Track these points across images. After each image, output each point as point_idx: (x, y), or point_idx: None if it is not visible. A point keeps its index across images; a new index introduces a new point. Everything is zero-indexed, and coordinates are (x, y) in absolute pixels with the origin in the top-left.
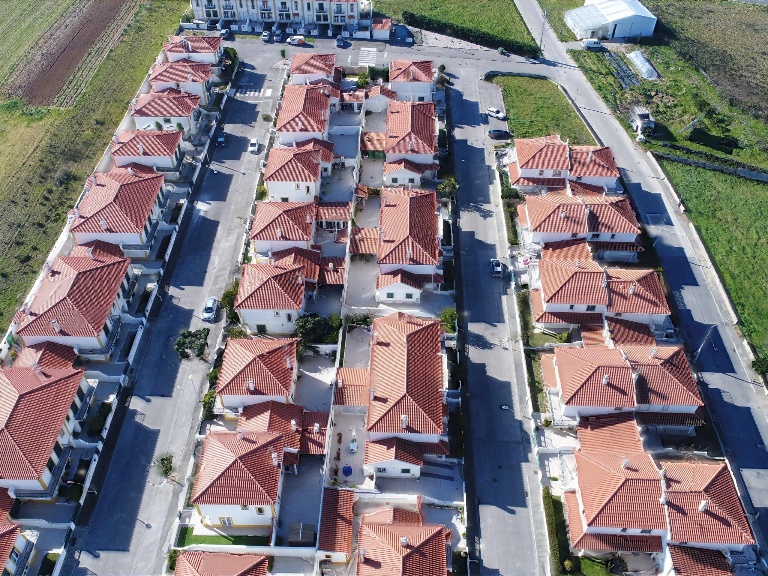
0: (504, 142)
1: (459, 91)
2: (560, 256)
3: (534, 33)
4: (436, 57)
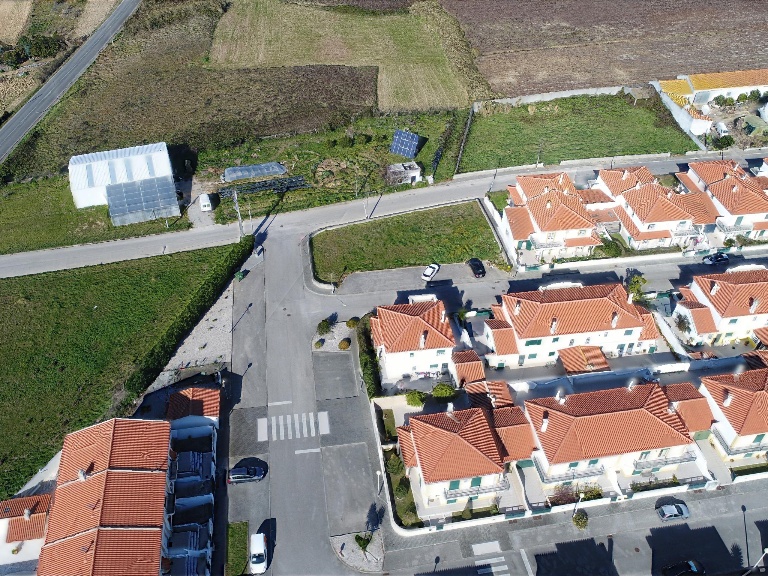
0: (490, 265)
1: (373, 311)
2: (698, 212)
3: (161, 252)
4: (272, 342)
